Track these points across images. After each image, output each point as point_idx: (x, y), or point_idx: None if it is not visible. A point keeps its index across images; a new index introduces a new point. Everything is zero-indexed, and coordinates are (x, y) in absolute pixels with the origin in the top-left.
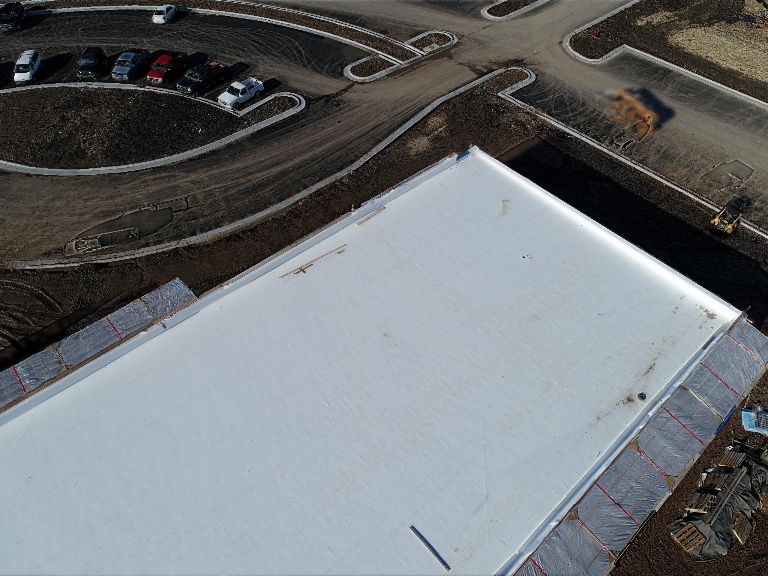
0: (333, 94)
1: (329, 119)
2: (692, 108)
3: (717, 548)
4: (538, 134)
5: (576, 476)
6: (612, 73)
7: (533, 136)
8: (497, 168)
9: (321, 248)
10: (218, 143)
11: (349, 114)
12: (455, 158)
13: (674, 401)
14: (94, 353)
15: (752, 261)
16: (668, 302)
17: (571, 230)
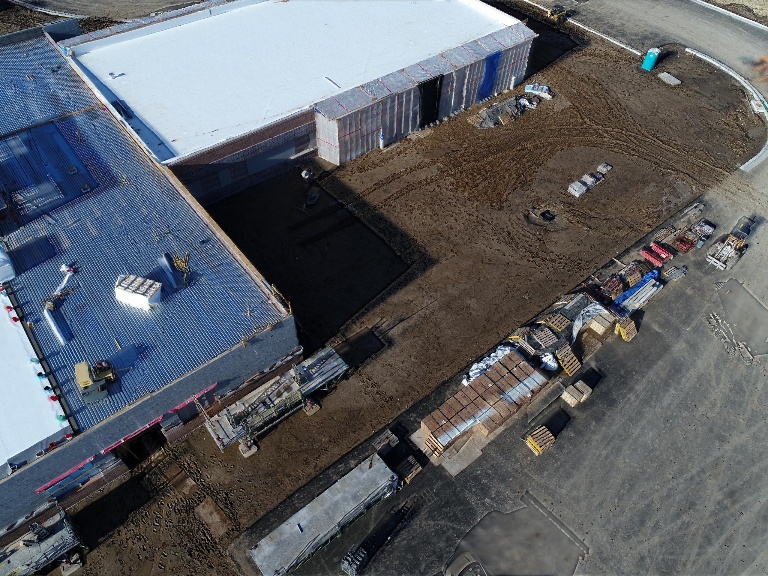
0: None
1: None
2: None
3: (489, 124)
4: None
5: None
6: None
7: None
8: None
9: None
10: None
11: None
12: None
13: (468, 44)
14: (176, 15)
15: (565, 34)
16: (487, 22)
17: None
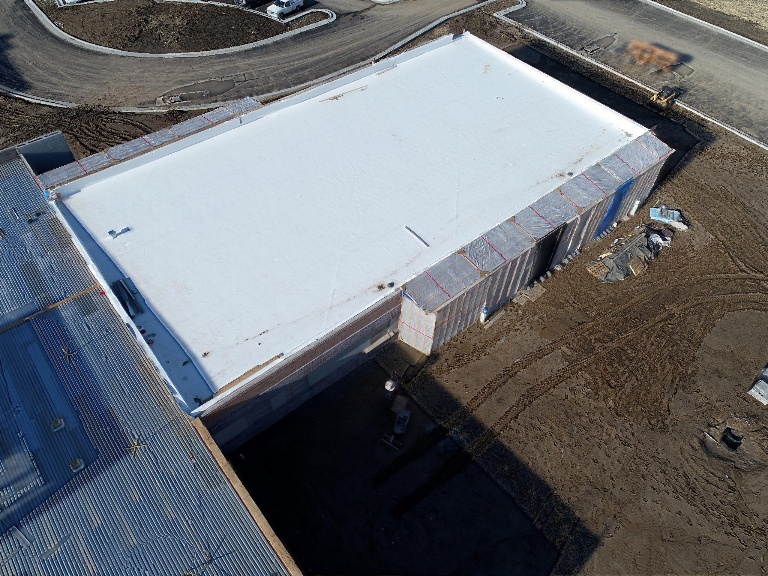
0: (359, 11)
1: (355, 27)
2: (652, 28)
3: (617, 276)
4: (523, 41)
5: (518, 209)
6: (590, 2)
7: (519, 42)
8: (483, 46)
9: (349, 87)
10: (267, 40)
11: (371, 25)
12: (451, 37)
13: (590, 171)
14: (195, 129)
15: (679, 125)
16: (599, 126)
17: (534, 84)
